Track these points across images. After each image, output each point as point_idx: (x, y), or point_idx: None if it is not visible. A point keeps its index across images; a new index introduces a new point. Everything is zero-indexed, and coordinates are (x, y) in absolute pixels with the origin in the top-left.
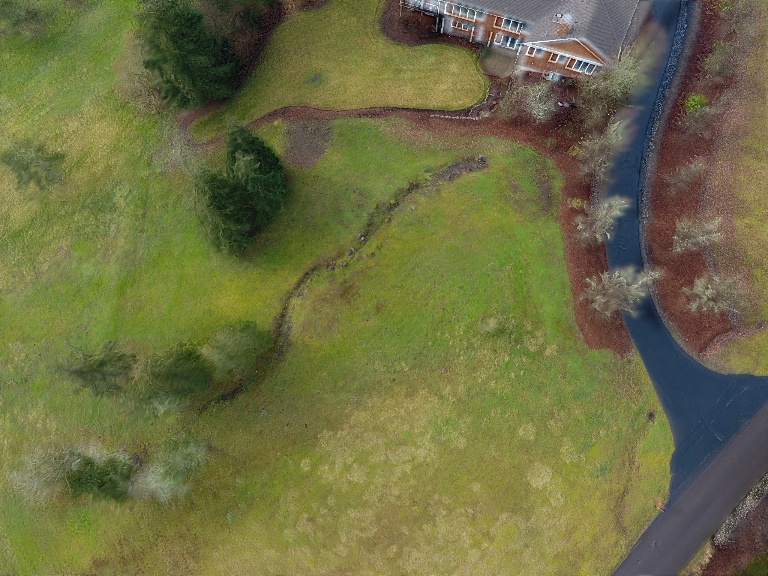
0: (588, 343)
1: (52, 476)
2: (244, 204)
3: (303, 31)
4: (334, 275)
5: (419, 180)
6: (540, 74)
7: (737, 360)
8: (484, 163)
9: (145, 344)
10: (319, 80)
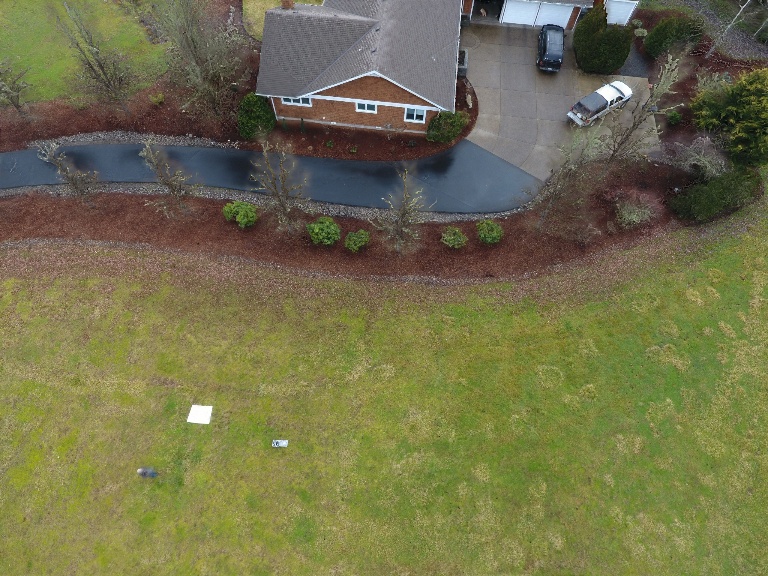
0: None
1: None
2: None
3: None
4: None
5: (145, 5)
6: None
7: None
8: None
9: None
10: None
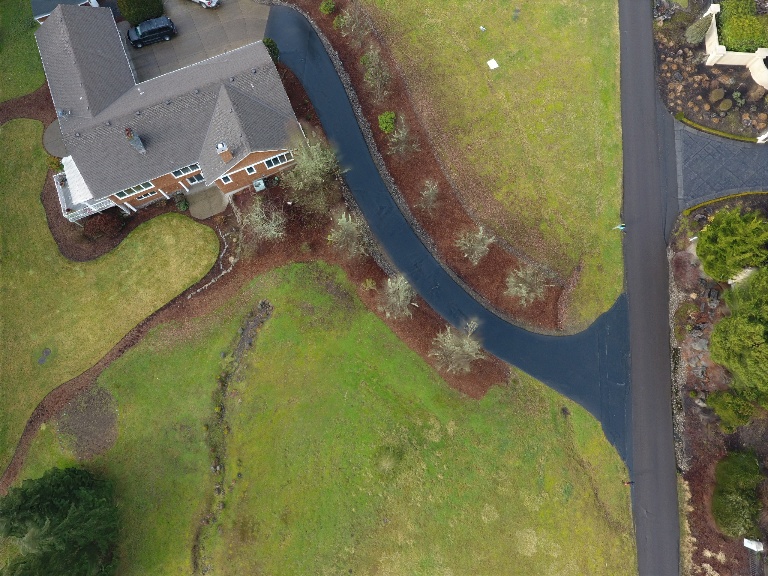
0: (474, 396)
1: None
2: (71, 553)
3: None
4: (220, 526)
5: (225, 368)
6: (252, 186)
7: (585, 310)
8: (269, 305)
9: None
10: (53, 349)
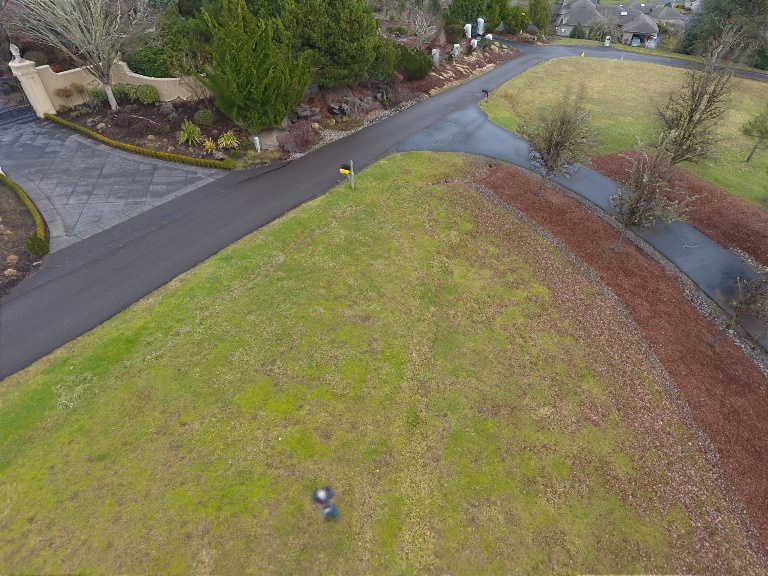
0: None
1: None
2: None
3: None
4: None
5: None
6: None
7: (454, 159)
8: None
9: None
10: None
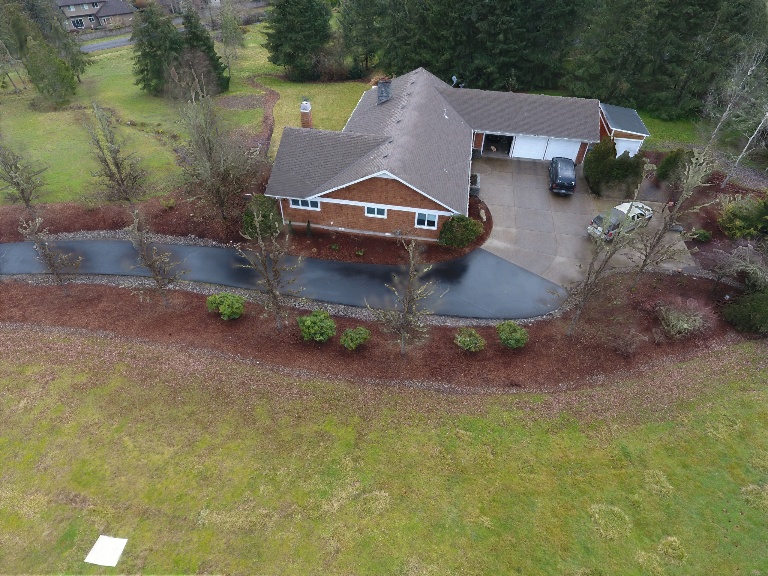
0: None
1: (27, 75)
2: None
3: (356, 90)
4: None
5: None
6: None
7: None
8: None
9: (97, 82)
10: None
